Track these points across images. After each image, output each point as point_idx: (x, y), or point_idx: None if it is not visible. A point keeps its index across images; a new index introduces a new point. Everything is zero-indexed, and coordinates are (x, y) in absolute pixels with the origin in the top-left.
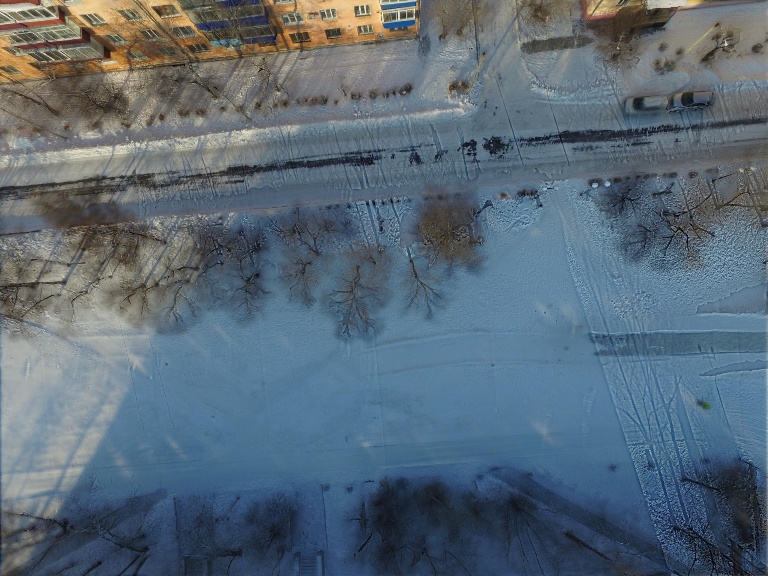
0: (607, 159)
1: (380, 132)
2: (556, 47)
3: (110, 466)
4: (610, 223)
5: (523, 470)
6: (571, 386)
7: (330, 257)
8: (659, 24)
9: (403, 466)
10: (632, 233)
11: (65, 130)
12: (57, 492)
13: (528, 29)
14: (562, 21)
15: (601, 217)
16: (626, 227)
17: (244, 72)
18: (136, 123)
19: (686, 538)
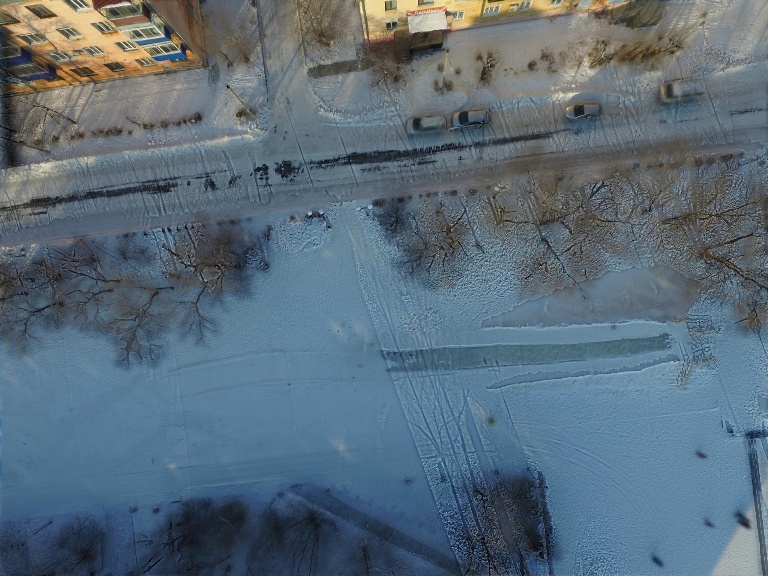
0: (394, 179)
1: (175, 160)
2: (341, 71)
3: None
4: (396, 242)
5: (322, 486)
6: (365, 402)
7: (130, 284)
8: (436, 45)
9: (207, 486)
10: (411, 252)
11: None
12: None
13: (313, 54)
14: (346, 45)
15: (387, 236)
16: (412, 245)
17: None
18: None
19: (479, 548)
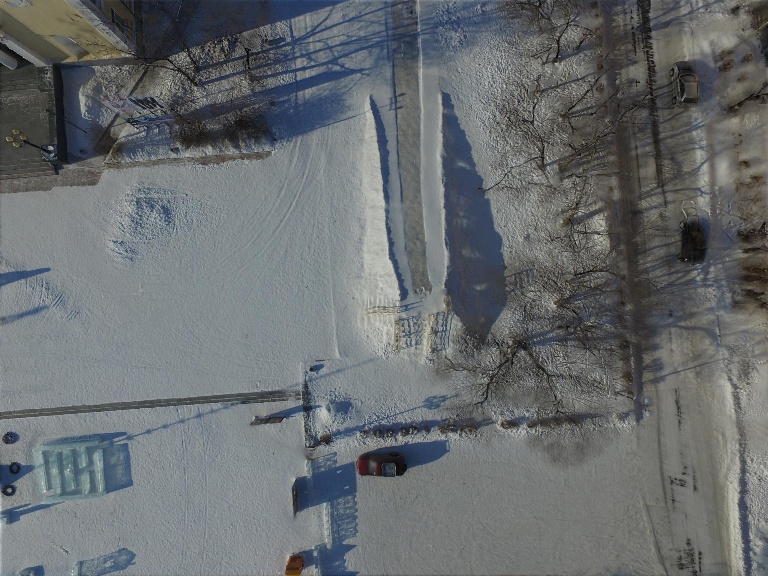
0: (617, 4)
1: None
2: None
3: None
4: None
5: None
6: None
7: None
8: None
9: None
10: None
11: None
12: None
13: None
14: None
15: None
16: None
17: None
18: None
19: (185, 80)
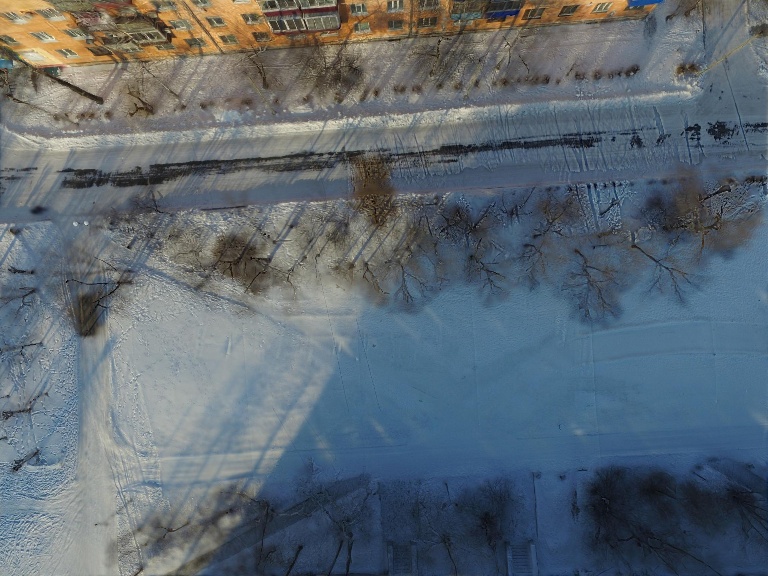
0: None
1: (601, 114)
2: None
3: (311, 449)
4: None
5: (743, 462)
6: None
7: (547, 240)
8: None
9: (619, 455)
10: None
11: (274, 104)
12: (255, 474)
13: (757, 12)
14: None
15: None
16: None
17: (462, 49)
18: (348, 98)
19: None
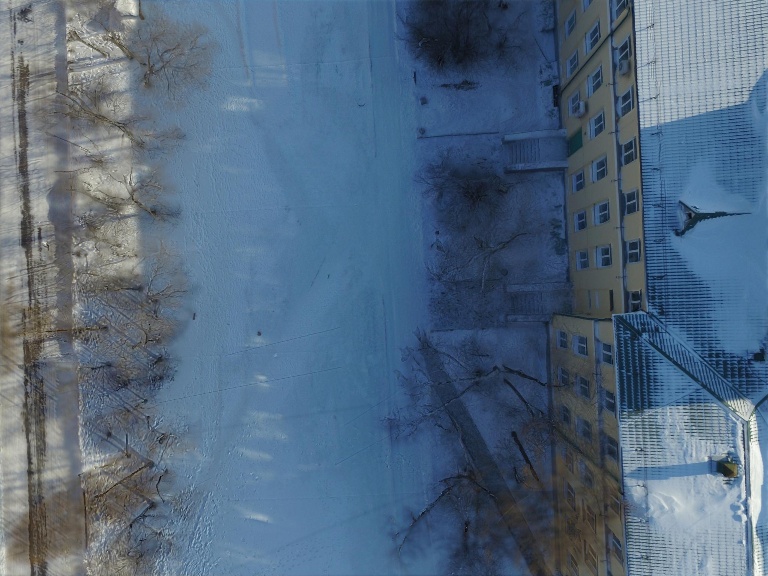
0: None
1: None
2: None
3: None
4: None
5: None
6: None
7: None
8: None
9: None
10: None
11: None
12: (421, 490)
13: None
14: None
15: None
16: None
17: None
18: None
19: None
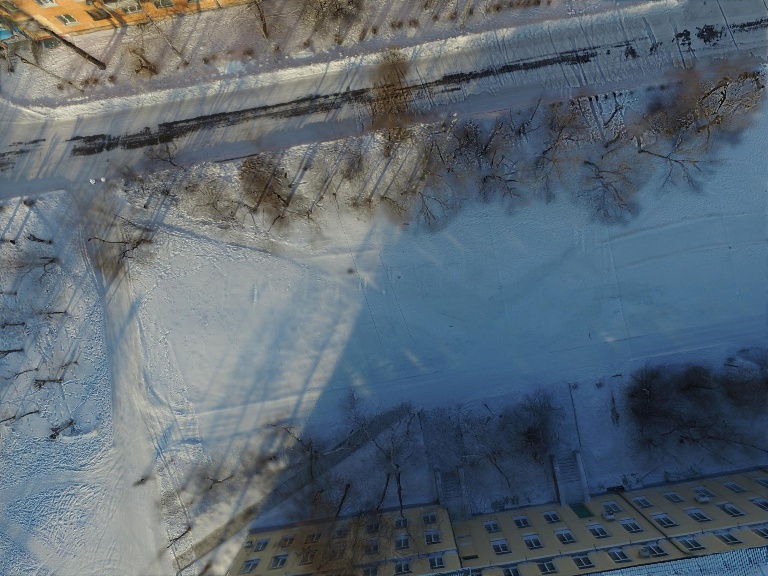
0: None
1: (594, 29)
2: None
3: (348, 387)
4: None
5: None
6: None
7: (557, 155)
8: None
9: (650, 356)
10: None
11: (276, 51)
12: (294, 419)
13: None
14: None
15: None
16: None
17: None
18: (347, 39)
19: None
